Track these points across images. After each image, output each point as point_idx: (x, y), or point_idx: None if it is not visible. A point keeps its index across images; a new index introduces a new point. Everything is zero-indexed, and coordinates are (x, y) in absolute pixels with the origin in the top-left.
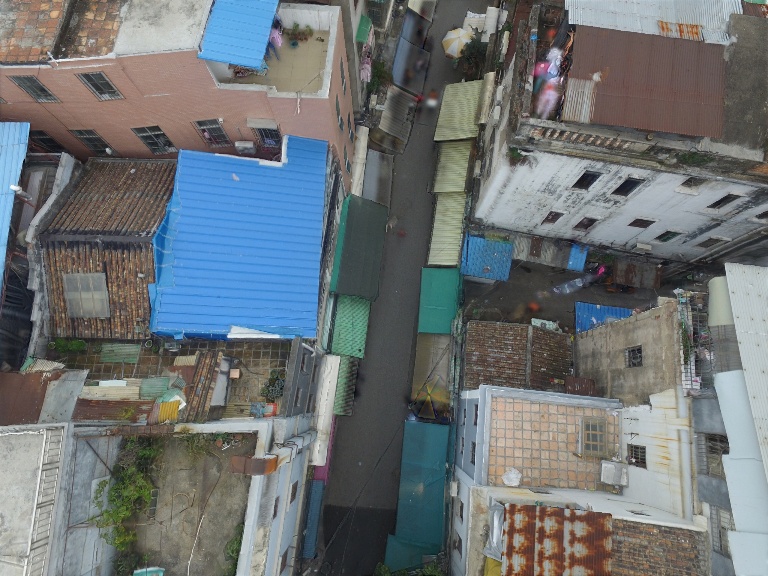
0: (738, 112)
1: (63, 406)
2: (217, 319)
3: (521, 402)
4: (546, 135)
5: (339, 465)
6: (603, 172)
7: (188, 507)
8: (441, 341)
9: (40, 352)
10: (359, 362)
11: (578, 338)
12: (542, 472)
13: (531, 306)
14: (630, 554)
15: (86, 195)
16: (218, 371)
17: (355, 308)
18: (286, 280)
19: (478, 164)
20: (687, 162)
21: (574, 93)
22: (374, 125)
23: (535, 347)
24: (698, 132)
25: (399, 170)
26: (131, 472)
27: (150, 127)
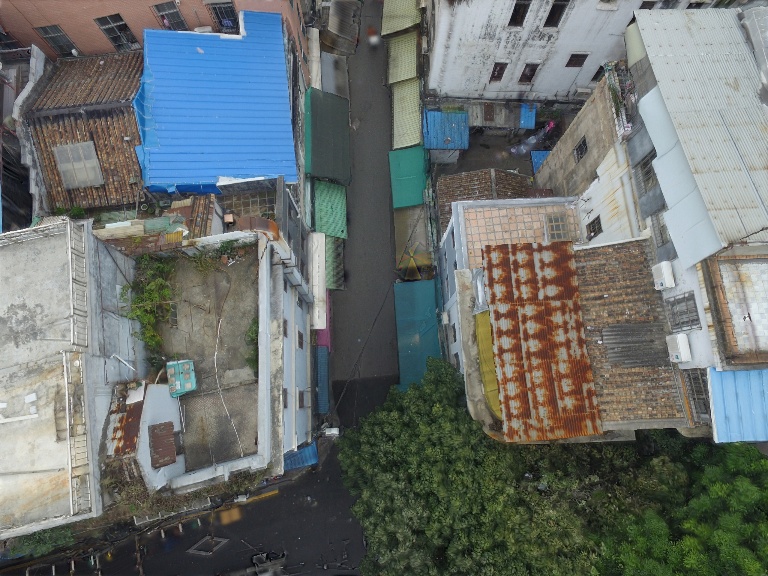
0: None
1: None
2: (204, 172)
3: (490, 210)
4: None
5: (340, 345)
6: None
7: (206, 315)
8: (416, 213)
9: None
10: (343, 243)
11: (536, 175)
12: None
13: None
14: (593, 274)
15: (61, 84)
16: (213, 208)
17: (332, 194)
18: (262, 136)
19: (424, 39)
20: None
21: None
22: (323, 27)
23: (499, 187)
24: None
25: (354, 77)
26: (150, 273)
27: (112, 16)
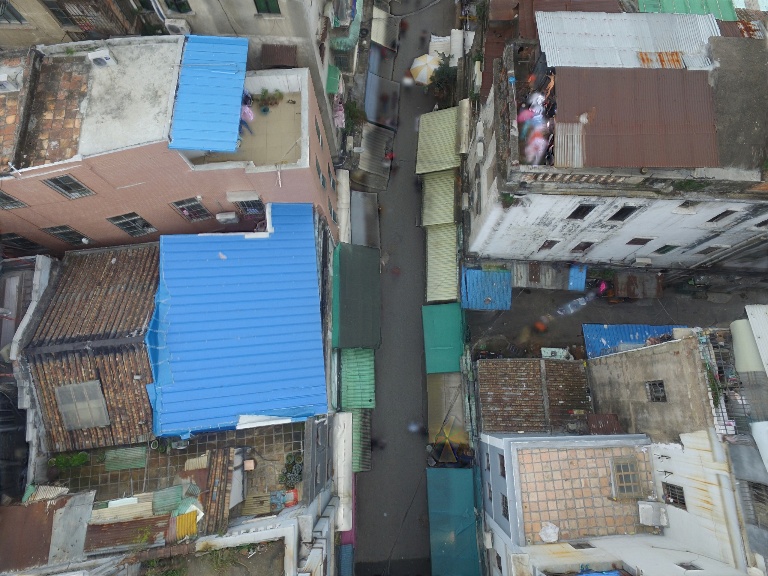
0: (729, 135)
1: (73, 536)
2: (223, 411)
3: (547, 451)
4: (538, 179)
5: (364, 519)
6: (598, 204)
7: None
8: (451, 379)
9: (40, 472)
10: (371, 412)
11: (591, 364)
12: (579, 522)
13: (536, 328)
14: None
15: (68, 296)
16: (232, 470)
17: (360, 358)
18: (289, 357)
19: (465, 197)
20: (684, 188)
21: (563, 138)
22: (354, 166)
23: (550, 380)
24: (694, 163)
25: (384, 204)
26: None
27: (126, 214)
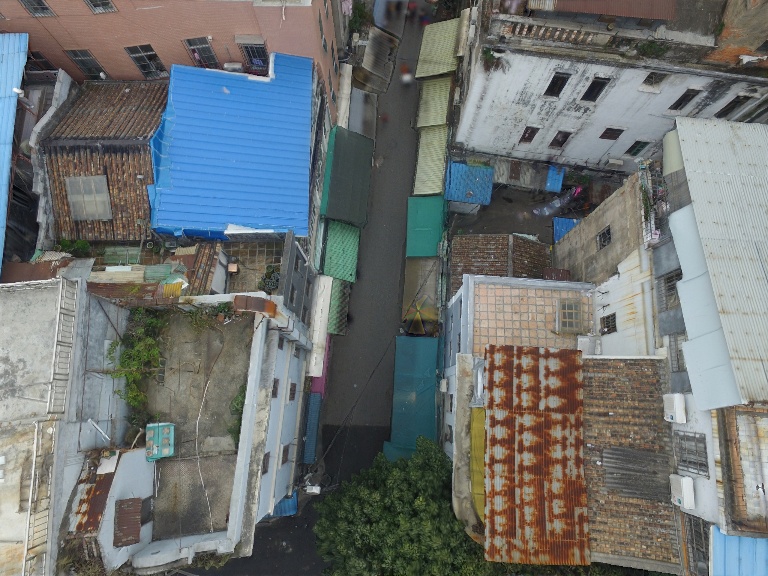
0: None
1: None
2: (214, 218)
3: (502, 287)
4: (516, 32)
5: (335, 388)
6: (571, 73)
7: (194, 374)
8: (428, 264)
9: None
10: (351, 286)
11: (556, 246)
12: None
13: None
14: (600, 387)
15: (84, 110)
16: (217, 259)
17: (345, 235)
18: (278, 184)
19: (457, 91)
20: (646, 53)
21: None
22: (357, 63)
23: (516, 254)
24: (653, 15)
25: (383, 113)
26: (141, 332)
27: (142, 46)
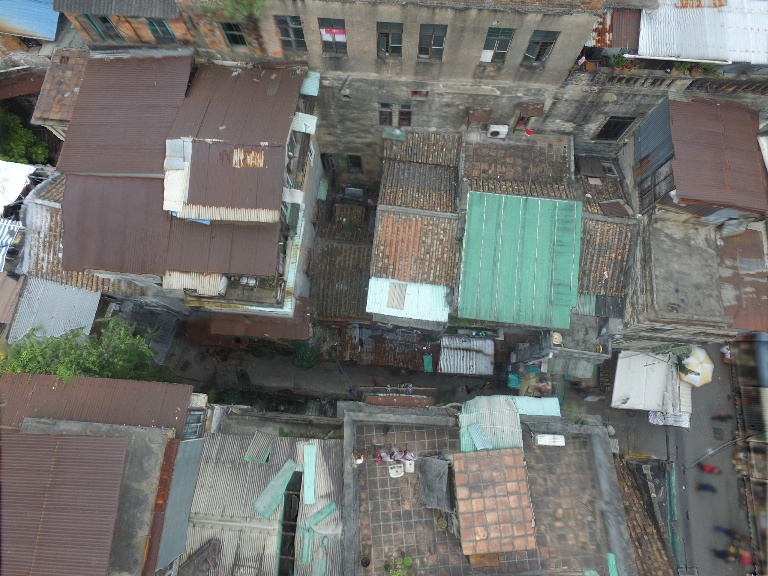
0: None
1: None
2: None
3: None
4: None
5: None
6: None
7: None
8: None
9: None
10: None
11: None
12: None
13: None
14: None
15: None
16: None
17: None
18: None
19: None
20: None
21: None
22: None
23: None
24: None
25: None
26: None
27: None
